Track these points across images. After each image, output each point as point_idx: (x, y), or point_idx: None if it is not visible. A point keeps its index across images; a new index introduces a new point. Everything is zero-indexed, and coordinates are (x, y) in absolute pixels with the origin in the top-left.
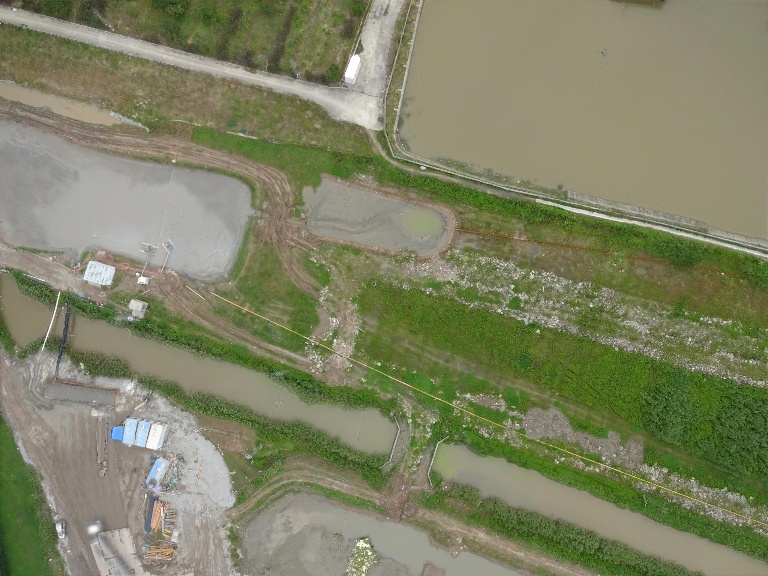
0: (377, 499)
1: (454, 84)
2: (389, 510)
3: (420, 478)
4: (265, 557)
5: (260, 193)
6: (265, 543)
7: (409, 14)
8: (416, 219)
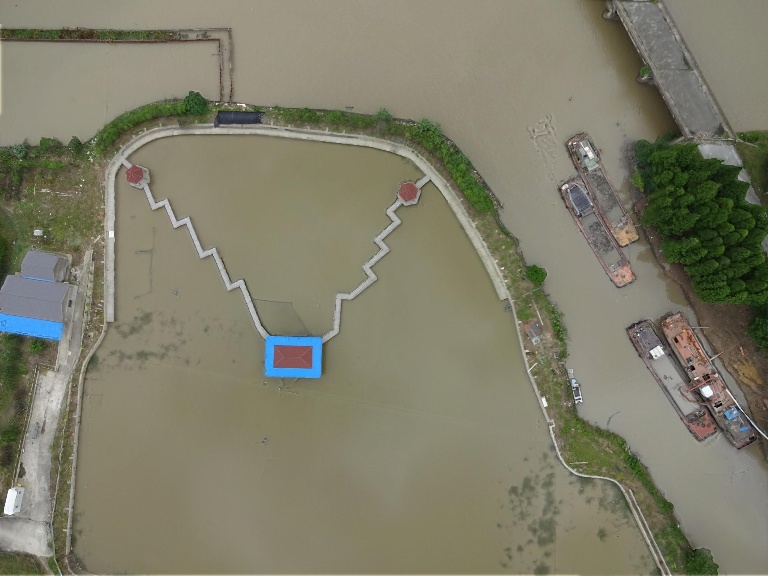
0: None
1: (120, 495)
2: None
3: None
4: None
5: None
6: None
7: (65, 430)
8: None
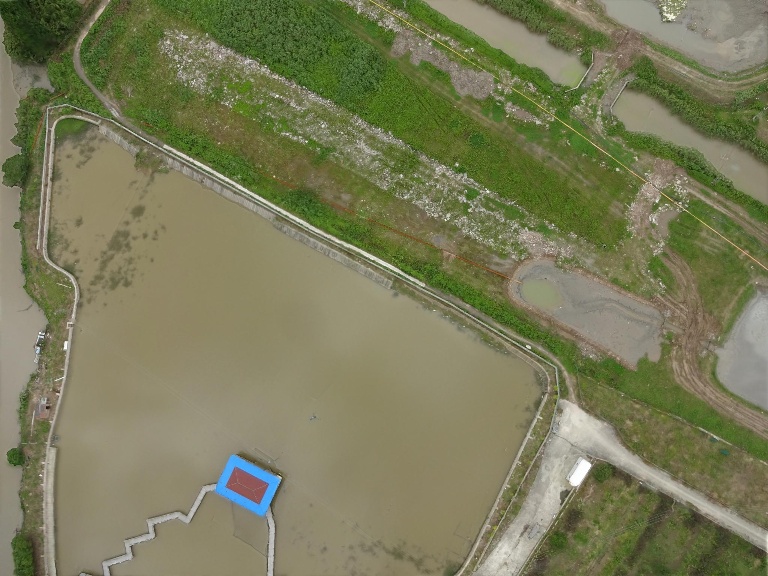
0: (648, 51)
1: (472, 428)
2: (639, 39)
3: (601, 62)
4: (767, 23)
5: (707, 368)
6: (765, 35)
7: (502, 518)
8: (547, 299)
